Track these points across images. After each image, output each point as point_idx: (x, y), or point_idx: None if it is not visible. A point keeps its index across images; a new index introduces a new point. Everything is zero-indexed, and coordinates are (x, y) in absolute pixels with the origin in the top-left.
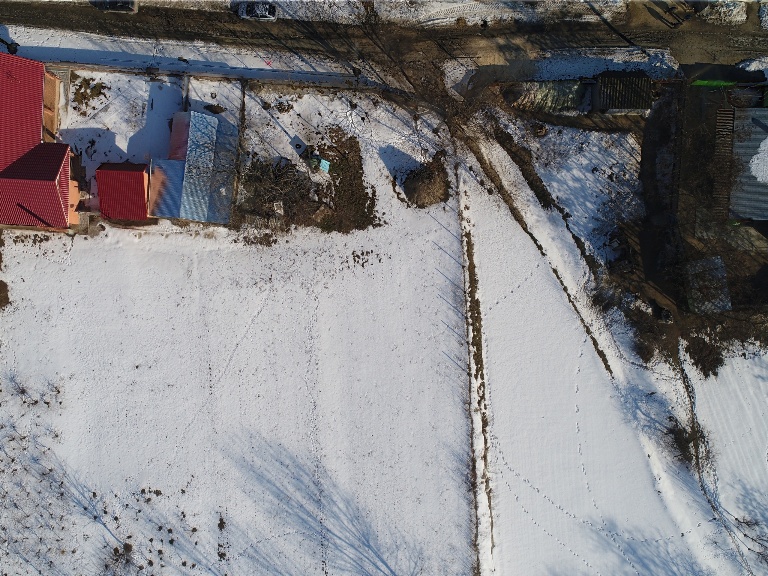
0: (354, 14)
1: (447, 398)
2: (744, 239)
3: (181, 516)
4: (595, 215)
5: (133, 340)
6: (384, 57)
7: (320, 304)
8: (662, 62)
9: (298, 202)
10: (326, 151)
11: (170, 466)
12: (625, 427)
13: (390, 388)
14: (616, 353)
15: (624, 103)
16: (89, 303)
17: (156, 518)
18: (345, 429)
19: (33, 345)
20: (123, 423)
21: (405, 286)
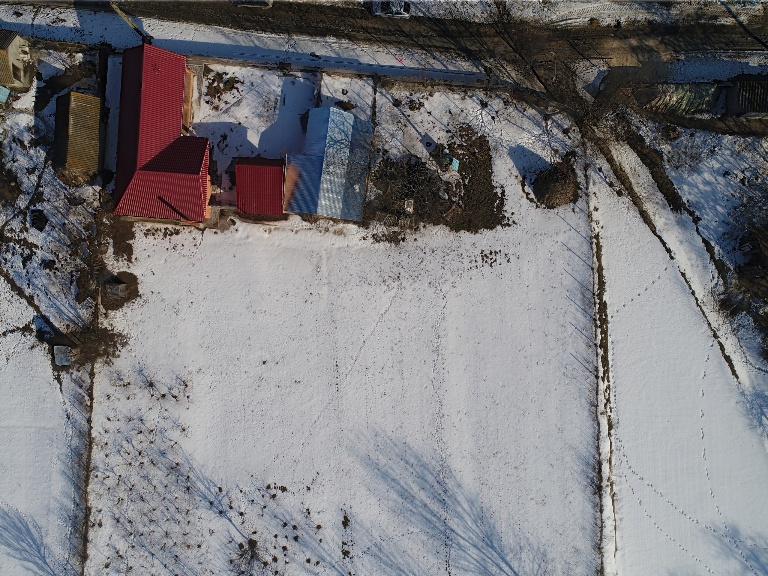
0: (486, 12)
1: (574, 400)
2: None
3: (306, 513)
4: (725, 219)
5: (261, 335)
6: (515, 56)
7: (448, 303)
8: None
9: (431, 200)
10: (456, 150)
11: (295, 462)
12: (750, 433)
13: (516, 389)
14: (742, 358)
15: (764, 107)
16: (218, 297)
17: (281, 514)
18: (470, 429)
19: (162, 338)
20: (249, 418)
21: (533, 287)
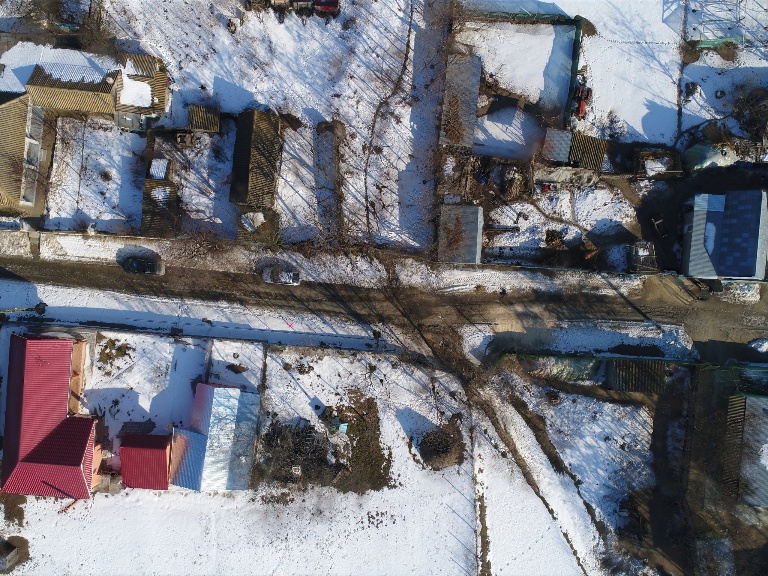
0: (376, 278)
1: None
2: (752, 514)
3: None
4: (606, 482)
5: None
6: (404, 320)
7: (334, 564)
8: (676, 341)
9: (316, 469)
10: (344, 412)
11: None
12: None
13: None
14: None
15: (638, 387)
16: (108, 559)
17: None
18: None
19: None
20: None
21: (418, 548)
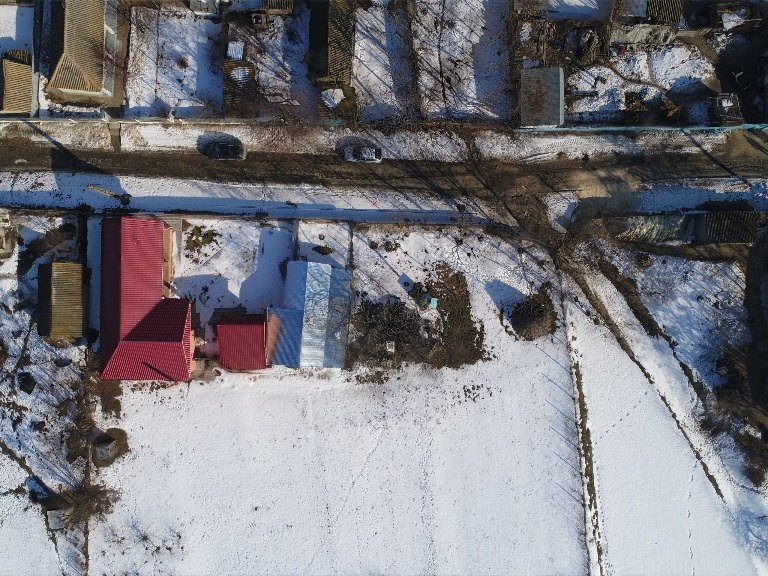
0: (456, 151)
1: (562, 529)
2: None
3: None
4: (701, 342)
5: (251, 482)
6: (487, 193)
7: (433, 440)
8: (765, 193)
9: (411, 343)
10: (434, 287)
11: None
12: (738, 550)
13: (505, 521)
14: (726, 476)
15: (731, 238)
16: (207, 447)
17: None
18: (462, 563)
19: (153, 492)
20: (244, 565)
21: (516, 419)
